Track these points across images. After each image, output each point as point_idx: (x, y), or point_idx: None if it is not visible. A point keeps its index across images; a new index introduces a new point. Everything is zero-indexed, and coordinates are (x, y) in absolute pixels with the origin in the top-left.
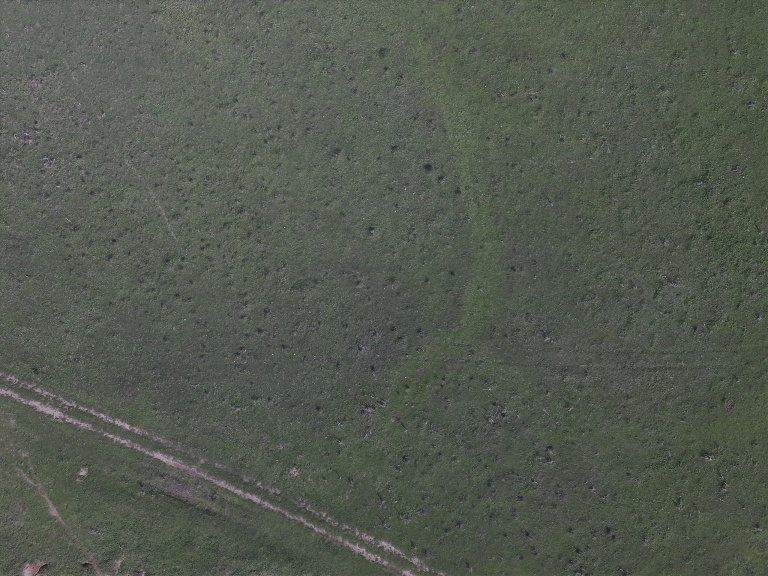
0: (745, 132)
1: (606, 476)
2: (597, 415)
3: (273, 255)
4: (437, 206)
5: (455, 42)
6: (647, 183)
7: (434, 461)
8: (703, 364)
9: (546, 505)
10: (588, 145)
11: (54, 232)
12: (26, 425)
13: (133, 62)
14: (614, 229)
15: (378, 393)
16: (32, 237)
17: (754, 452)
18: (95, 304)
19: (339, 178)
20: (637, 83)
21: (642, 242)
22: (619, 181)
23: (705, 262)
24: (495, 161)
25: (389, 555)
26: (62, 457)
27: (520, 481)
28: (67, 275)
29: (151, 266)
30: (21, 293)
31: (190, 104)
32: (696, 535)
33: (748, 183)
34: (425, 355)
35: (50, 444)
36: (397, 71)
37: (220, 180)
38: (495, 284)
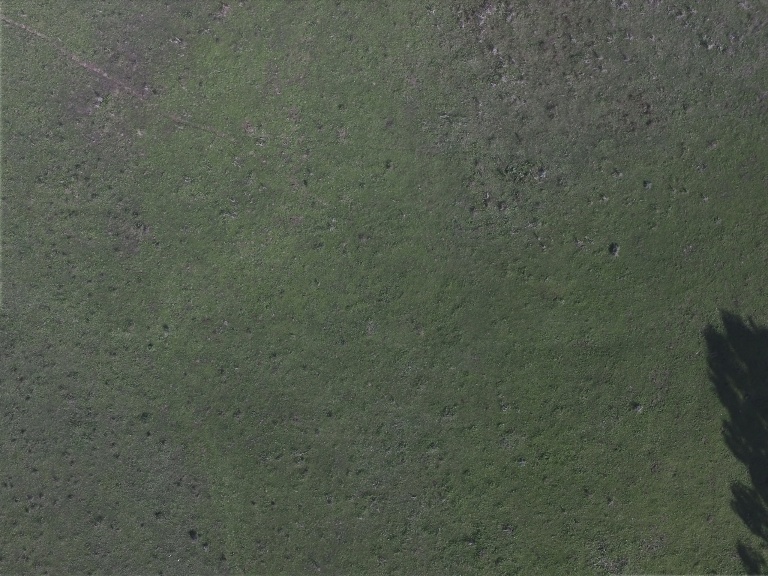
0: (516, 489)
1: None
2: None
3: None
4: (202, 573)
5: (219, 405)
6: (418, 542)
7: None
8: None
9: None
10: (357, 505)
11: None
12: None
13: None
14: None
15: None
16: None
17: None
18: None
19: (102, 546)
20: (407, 440)
21: None
22: (389, 541)
23: None
24: (261, 526)
25: None
26: None
27: None
28: None
29: None
30: None
31: None
32: None
33: (519, 543)
34: None
35: None
36: (160, 436)
37: None
38: None
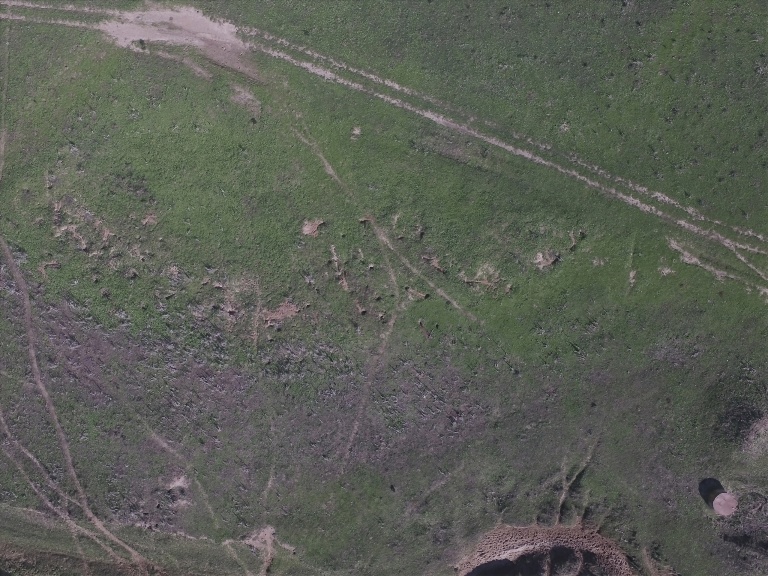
0: None
1: None
2: None
3: None
4: None
5: None
6: None
7: (704, 112)
8: None
9: None
10: None
11: None
12: (299, 86)
13: None
14: None
15: (645, 47)
16: None
17: None
18: None
19: None
20: None
21: None
22: None
23: None
24: None
25: (663, 205)
26: (335, 116)
27: None
28: None
29: None
30: None
31: None
32: None
33: None
34: (690, 9)
35: (323, 104)
36: None
37: None
38: None
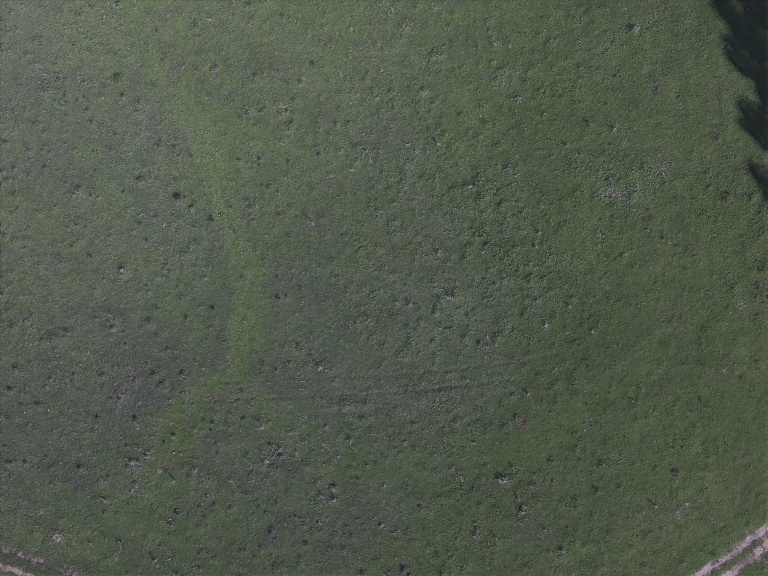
0: (514, 128)
1: (395, 509)
2: (381, 445)
3: (17, 305)
4: (190, 237)
5: (194, 60)
6: (415, 191)
7: (207, 511)
8: (490, 379)
9: (334, 547)
10: (348, 156)
11: None
12: None
13: None
14: (383, 244)
15: (142, 443)
16: None
17: (551, 469)
18: None
19: (82, 216)
20: (395, 86)
21: (414, 255)
22: (385, 192)
23: (483, 270)
24: (248, 183)
25: None
26: None
27: (303, 524)
28: None
29: None
30: None
31: None
32: (496, 564)
33: (521, 182)
34: (190, 398)
35: None
36: (134, 96)
37: None
38: (259, 315)
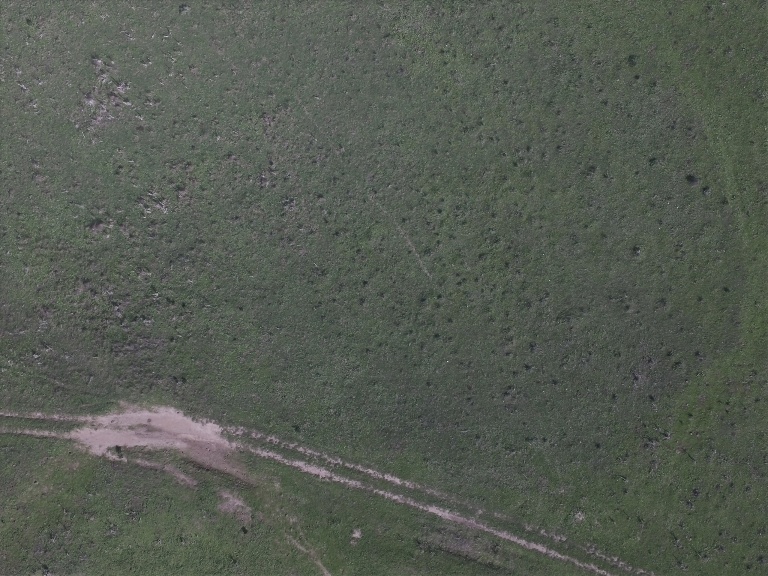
0: None
1: None
2: None
3: (534, 285)
4: (704, 219)
5: (708, 43)
6: None
7: (727, 492)
8: None
9: None
10: None
11: (301, 279)
12: (292, 488)
13: (368, 91)
14: None
15: (660, 424)
16: (278, 286)
17: None
18: (351, 352)
19: (596, 197)
20: None
21: None
22: None
23: None
24: (761, 166)
25: None
26: (333, 519)
27: None
28: (319, 323)
29: (406, 307)
30: (273, 347)
31: (432, 131)
32: None
33: None
34: (705, 379)
35: (318, 506)
36: (649, 79)
37: (471, 209)
38: None
